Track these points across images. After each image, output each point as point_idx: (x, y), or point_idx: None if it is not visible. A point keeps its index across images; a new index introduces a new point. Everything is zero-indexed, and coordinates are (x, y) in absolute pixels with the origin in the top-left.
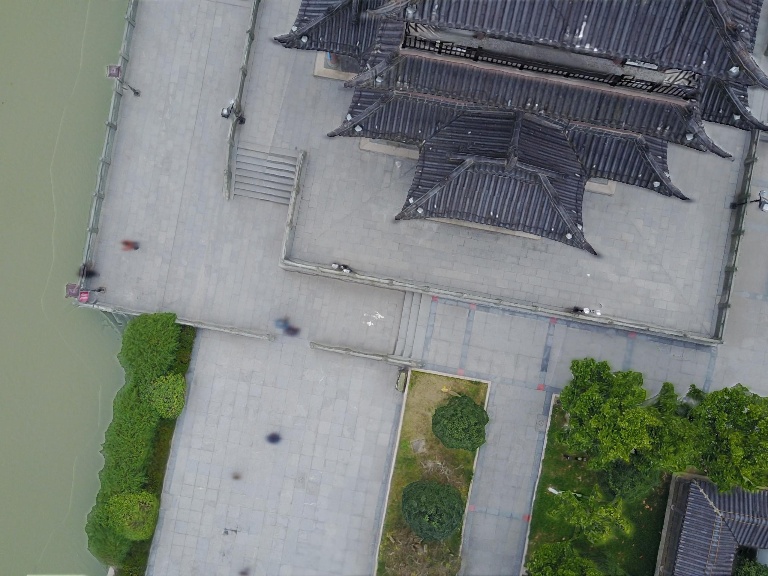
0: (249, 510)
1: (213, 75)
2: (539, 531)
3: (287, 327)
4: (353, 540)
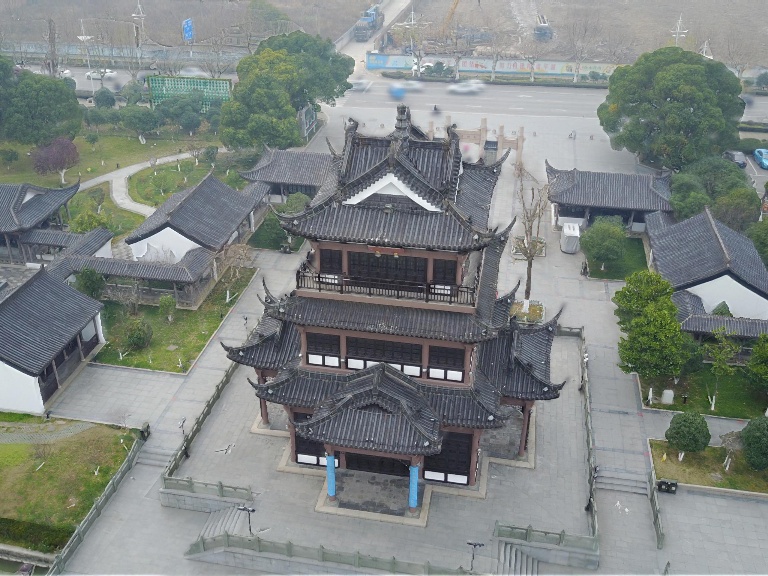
0: None
1: None
2: (746, 415)
3: (651, 566)
4: None
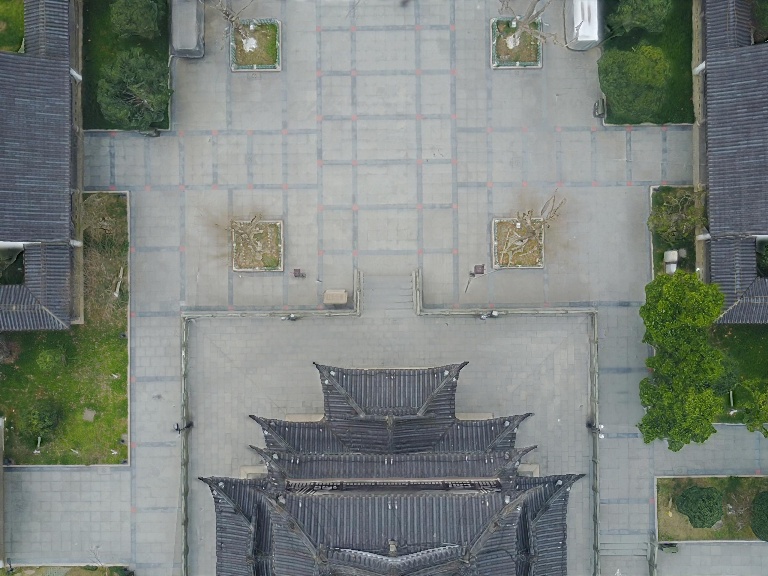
0: None
1: None
2: None
3: None
4: None
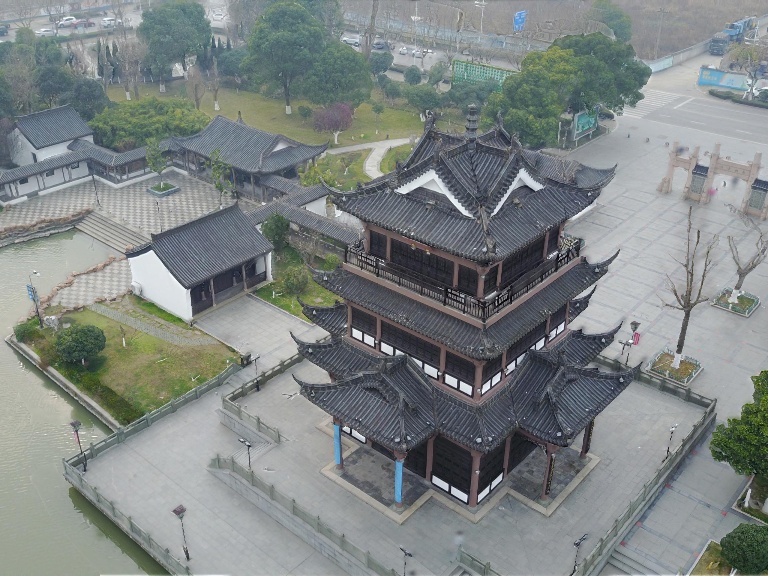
0: None
1: None
2: None
3: None
4: None
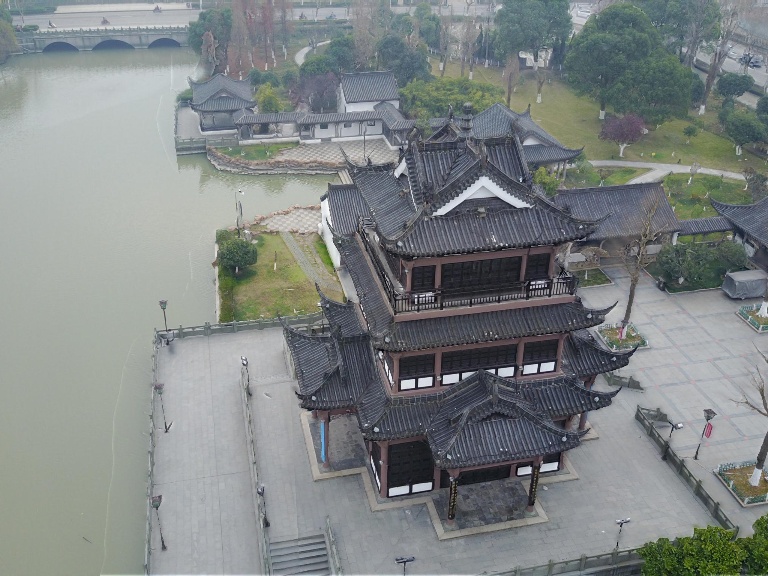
0: None
1: (228, 518)
2: None
3: None
4: None
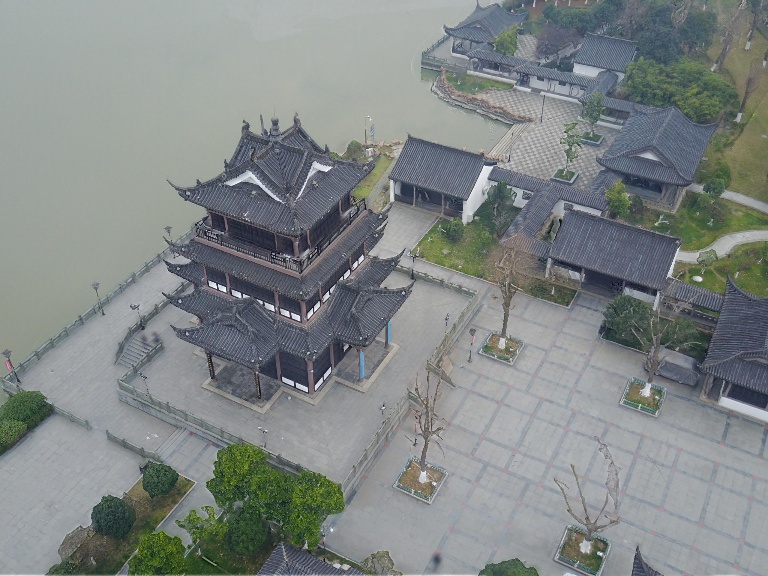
0: (6, 512)
1: None
2: None
3: (102, 426)
4: (55, 550)
